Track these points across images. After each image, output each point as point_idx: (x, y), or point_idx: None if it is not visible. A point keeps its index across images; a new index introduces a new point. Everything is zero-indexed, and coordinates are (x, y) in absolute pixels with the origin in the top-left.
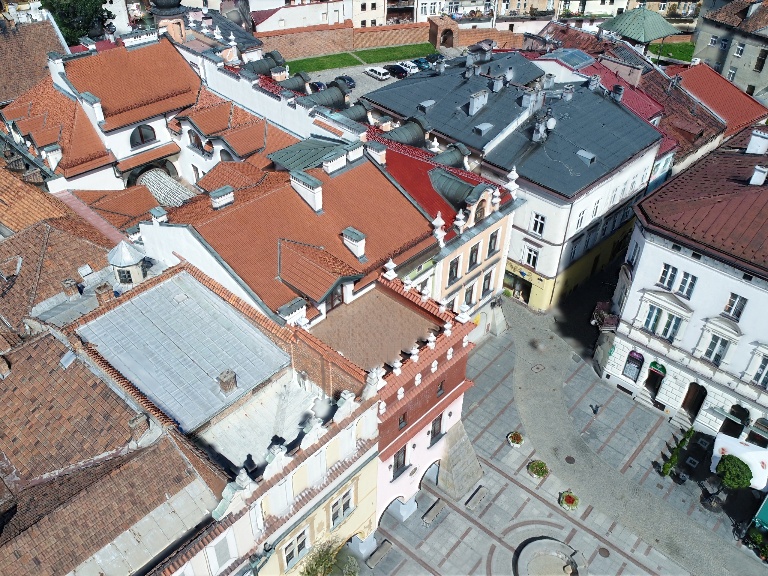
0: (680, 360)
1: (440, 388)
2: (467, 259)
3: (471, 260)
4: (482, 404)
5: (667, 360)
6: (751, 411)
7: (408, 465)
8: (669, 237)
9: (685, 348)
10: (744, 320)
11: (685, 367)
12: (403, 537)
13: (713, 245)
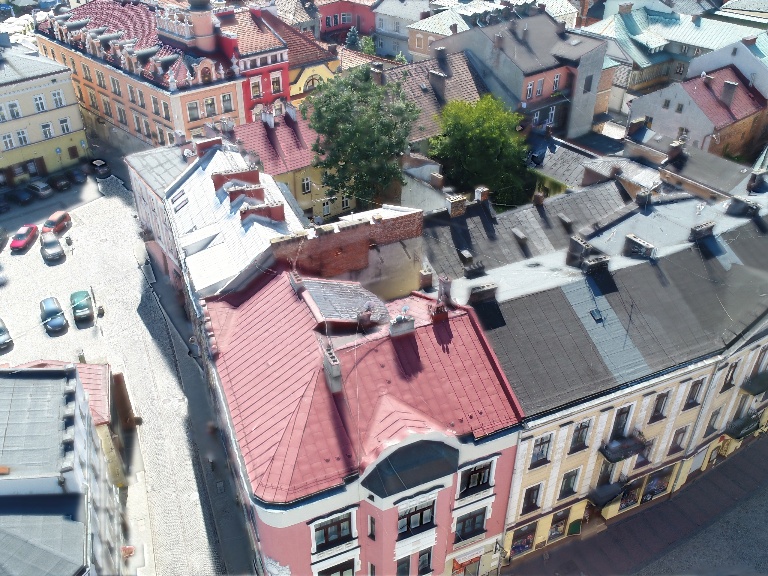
0: None
1: None
2: None
3: None
4: None
5: None
6: None
7: None
8: None
9: None
10: None
11: None
12: None
13: None
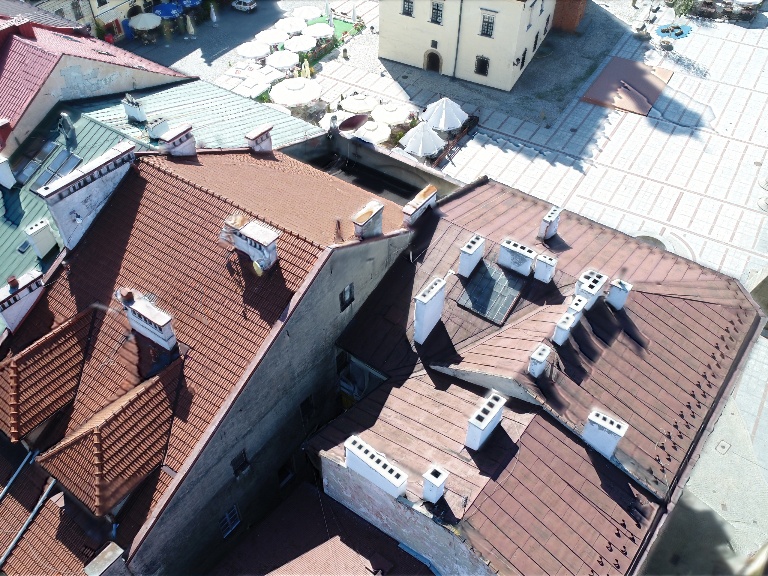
0: None
1: None
2: None
3: None
4: (765, 385)
5: None
6: None
7: None
8: None
9: None
10: None
11: None
12: (765, 261)
13: None
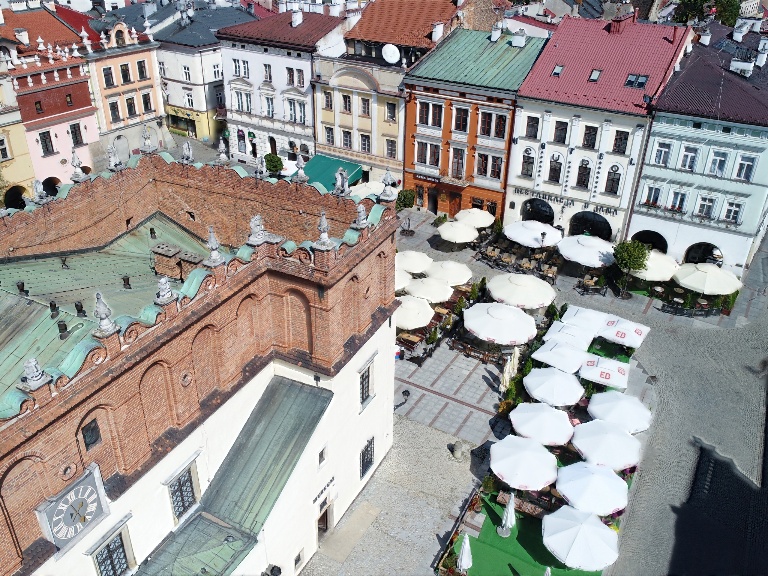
0: (258, 123)
1: (71, 102)
2: (119, 73)
3: (126, 78)
4: None
5: (253, 127)
6: (295, 142)
7: (56, 152)
8: (226, 37)
9: (258, 114)
10: (273, 79)
11: (260, 126)
12: None
13: (247, 36)
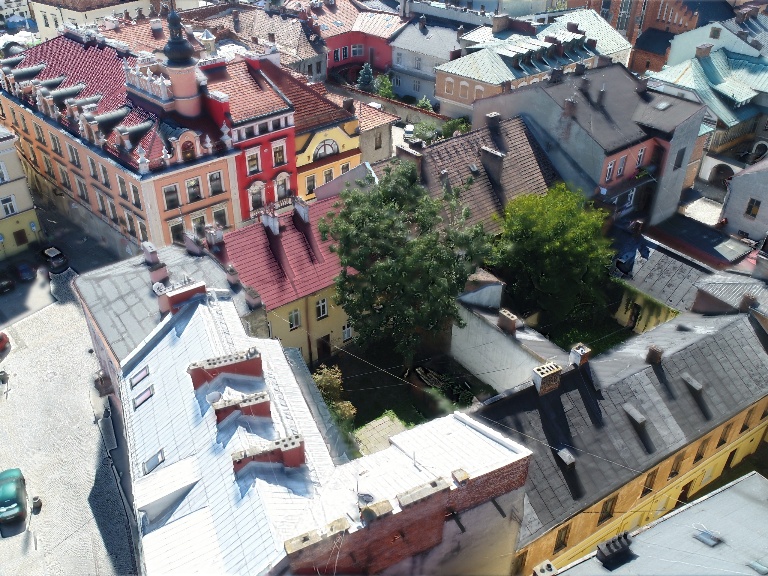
0: None
1: None
2: None
3: None
4: None
5: None
6: None
7: None
8: None
9: None
10: None
11: None
12: None
13: None
